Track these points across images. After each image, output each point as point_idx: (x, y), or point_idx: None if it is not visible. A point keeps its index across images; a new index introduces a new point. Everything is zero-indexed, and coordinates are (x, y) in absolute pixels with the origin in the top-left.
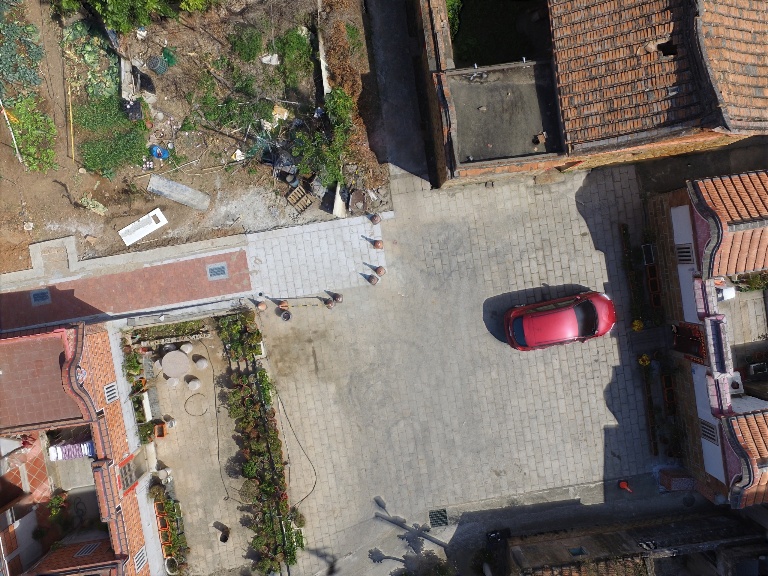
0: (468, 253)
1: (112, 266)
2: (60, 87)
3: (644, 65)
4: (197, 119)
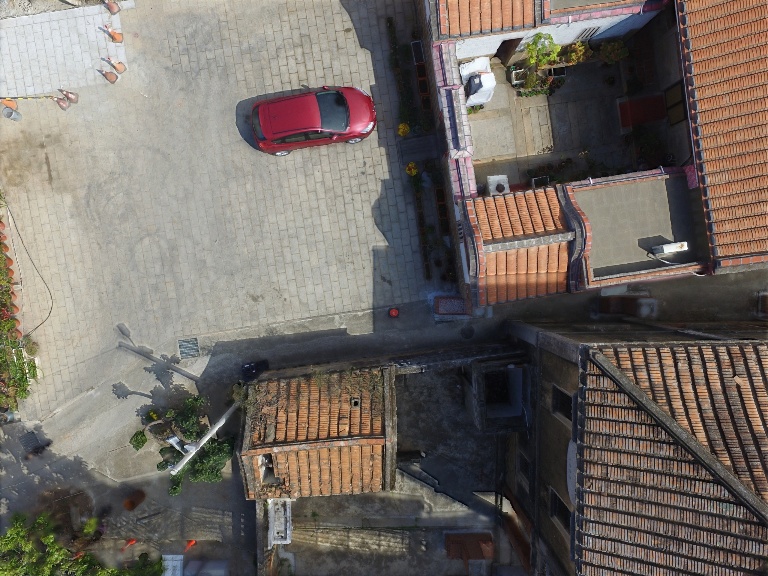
0: (218, 49)
1: None
2: None
3: None
4: None
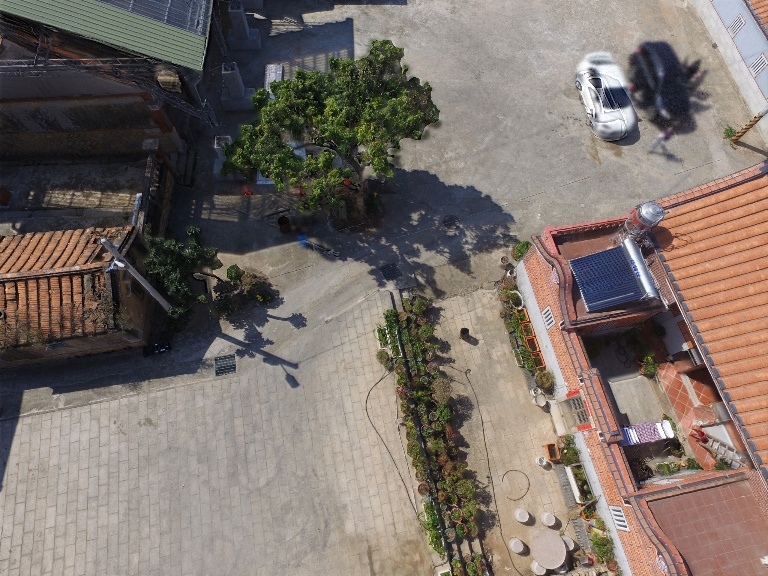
0: None
1: None
2: None
3: None
4: None
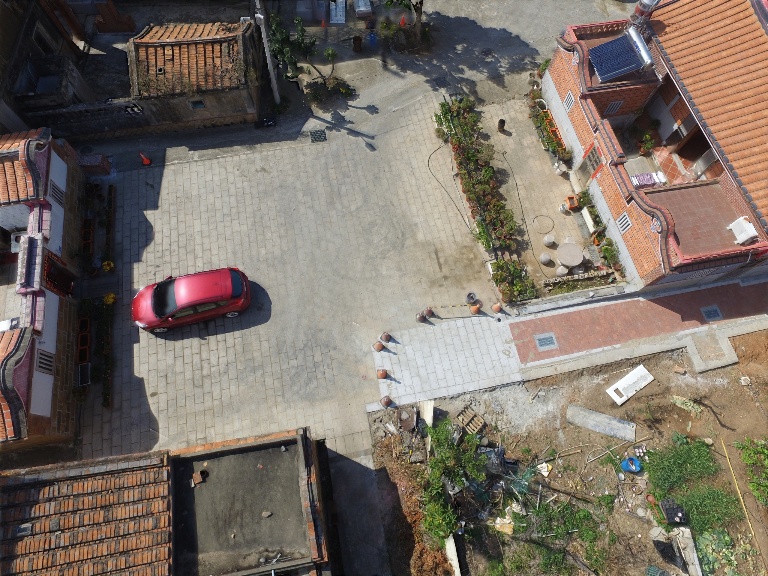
0: (285, 369)
1: (652, 344)
2: (763, 544)
3: (56, 569)
4: (599, 512)
